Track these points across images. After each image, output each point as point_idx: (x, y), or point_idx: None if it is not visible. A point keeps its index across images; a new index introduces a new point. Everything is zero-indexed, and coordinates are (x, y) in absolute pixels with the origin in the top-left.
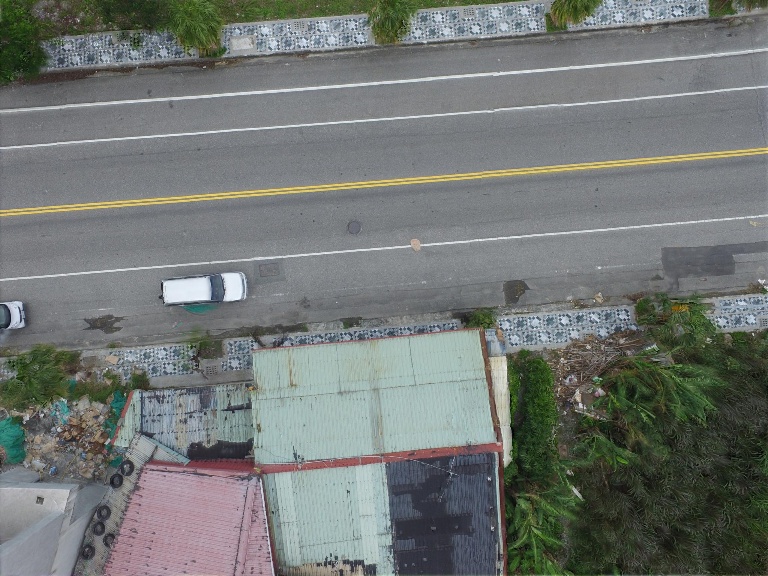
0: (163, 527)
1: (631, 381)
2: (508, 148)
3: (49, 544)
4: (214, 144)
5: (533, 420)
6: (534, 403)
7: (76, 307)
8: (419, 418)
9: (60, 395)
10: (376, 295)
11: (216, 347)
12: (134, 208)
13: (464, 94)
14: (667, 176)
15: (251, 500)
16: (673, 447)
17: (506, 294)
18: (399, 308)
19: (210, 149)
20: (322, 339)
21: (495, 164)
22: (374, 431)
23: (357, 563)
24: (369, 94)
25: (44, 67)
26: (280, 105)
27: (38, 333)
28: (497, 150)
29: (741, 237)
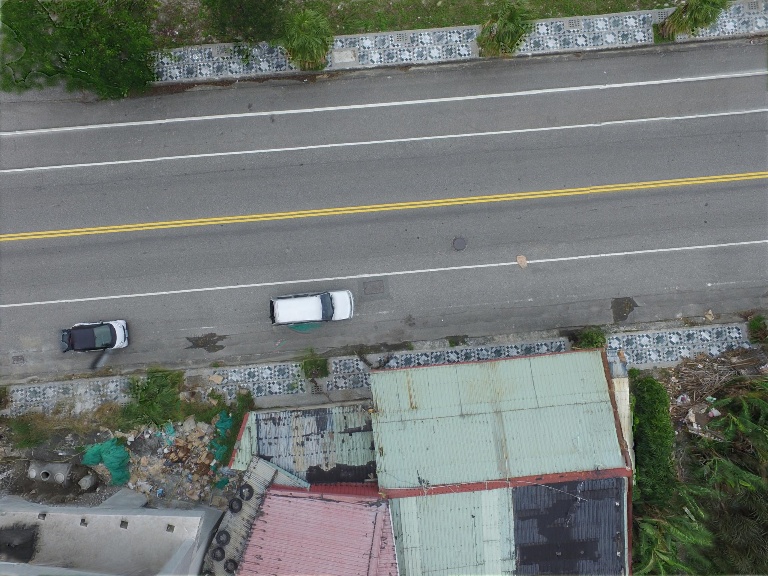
0: (289, 554)
1: (752, 402)
2: (615, 162)
3: (184, 573)
4: (316, 159)
5: (652, 442)
6: (652, 424)
7: (178, 325)
8: (544, 441)
9: None
10: (482, 313)
11: (321, 366)
12: (236, 225)
13: (570, 107)
14: None
15: (380, 527)
16: None
17: (614, 311)
18: (505, 326)
19: (313, 164)
20: (428, 358)
21: (602, 179)
22: (499, 455)
23: None
24: (473, 107)
25: (143, 81)
26: (382, 119)
27: (140, 352)
28: (604, 165)
29: None
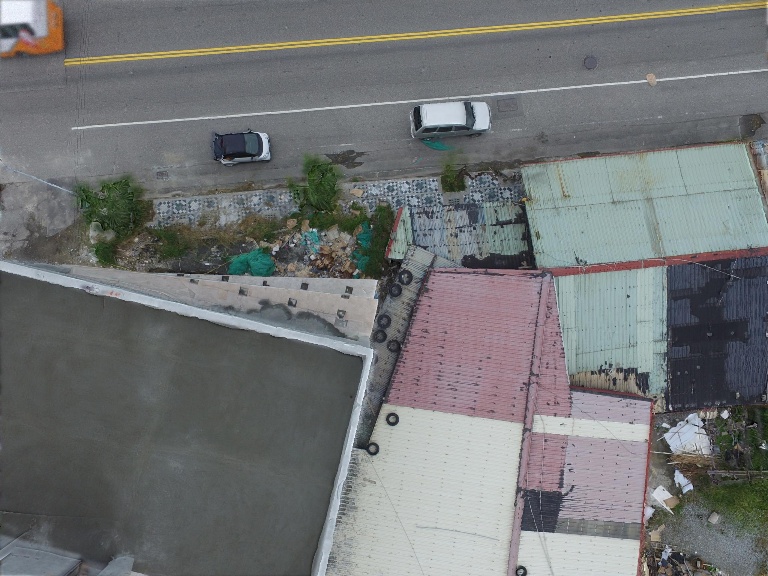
0: (455, 326)
1: None
2: None
3: None
4: None
5: None
6: None
7: (318, 142)
8: (695, 225)
9: (310, 225)
10: (613, 130)
11: None
12: (373, 44)
13: None
14: None
15: (546, 296)
16: None
17: (742, 128)
18: (636, 143)
19: None
20: None
21: None
22: (652, 237)
23: (630, 372)
24: None
25: None
26: None
27: (281, 168)
28: None
29: None
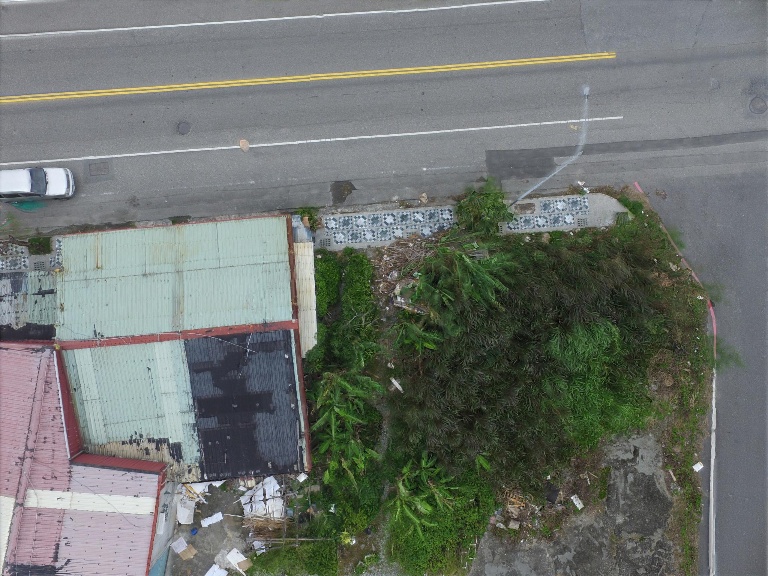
0: None
1: (439, 270)
2: (337, 53)
3: None
4: (45, 45)
5: (345, 308)
6: (347, 293)
7: None
8: (221, 299)
9: None
10: (205, 194)
11: (44, 243)
12: None
13: None
14: (491, 81)
15: (44, 371)
16: (467, 327)
17: (333, 194)
18: (228, 207)
19: (41, 50)
20: None
21: (324, 68)
22: (175, 310)
23: (162, 441)
24: None
25: None
26: (113, 8)
27: None
28: (326, 54)
29: (562, 140)
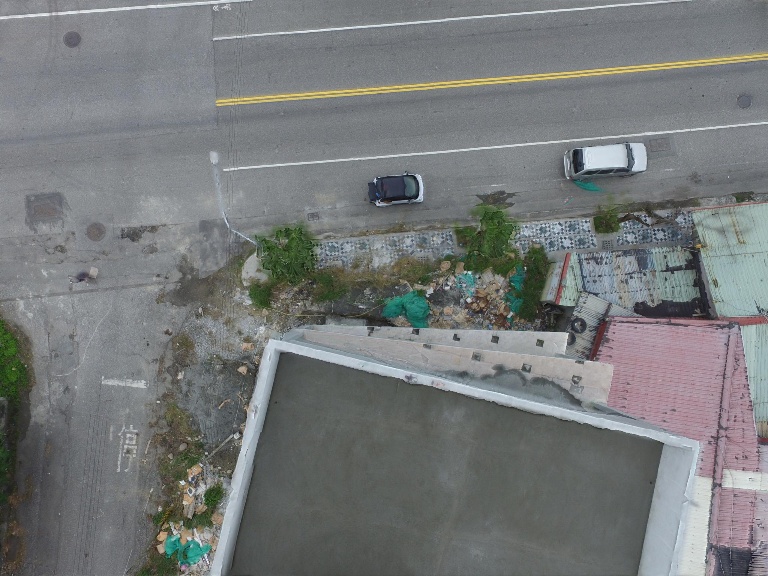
0: (638, 377)
1: None
2: None
3: None
4: (600, 19)
5: None
6: None
7: (468, 183)
8: None
9: (465, 267)
10: (767, 169)
11: None
12: (525, 83)
13: None
14: None
15: (734, 348)
16: None
17: None
18: None
19: (597, 24)
20: None
21: None
22: None
23: None
24: None
25: None
26: None
27: (432, 209)
28: None
29: None
